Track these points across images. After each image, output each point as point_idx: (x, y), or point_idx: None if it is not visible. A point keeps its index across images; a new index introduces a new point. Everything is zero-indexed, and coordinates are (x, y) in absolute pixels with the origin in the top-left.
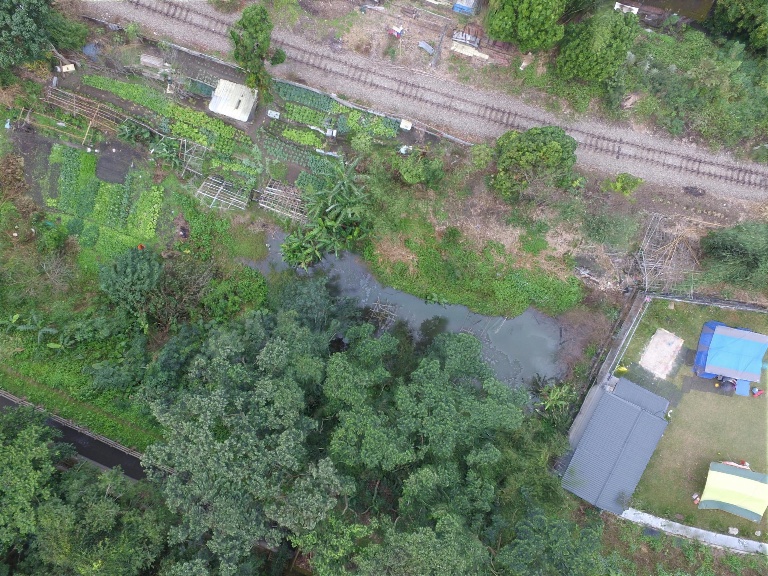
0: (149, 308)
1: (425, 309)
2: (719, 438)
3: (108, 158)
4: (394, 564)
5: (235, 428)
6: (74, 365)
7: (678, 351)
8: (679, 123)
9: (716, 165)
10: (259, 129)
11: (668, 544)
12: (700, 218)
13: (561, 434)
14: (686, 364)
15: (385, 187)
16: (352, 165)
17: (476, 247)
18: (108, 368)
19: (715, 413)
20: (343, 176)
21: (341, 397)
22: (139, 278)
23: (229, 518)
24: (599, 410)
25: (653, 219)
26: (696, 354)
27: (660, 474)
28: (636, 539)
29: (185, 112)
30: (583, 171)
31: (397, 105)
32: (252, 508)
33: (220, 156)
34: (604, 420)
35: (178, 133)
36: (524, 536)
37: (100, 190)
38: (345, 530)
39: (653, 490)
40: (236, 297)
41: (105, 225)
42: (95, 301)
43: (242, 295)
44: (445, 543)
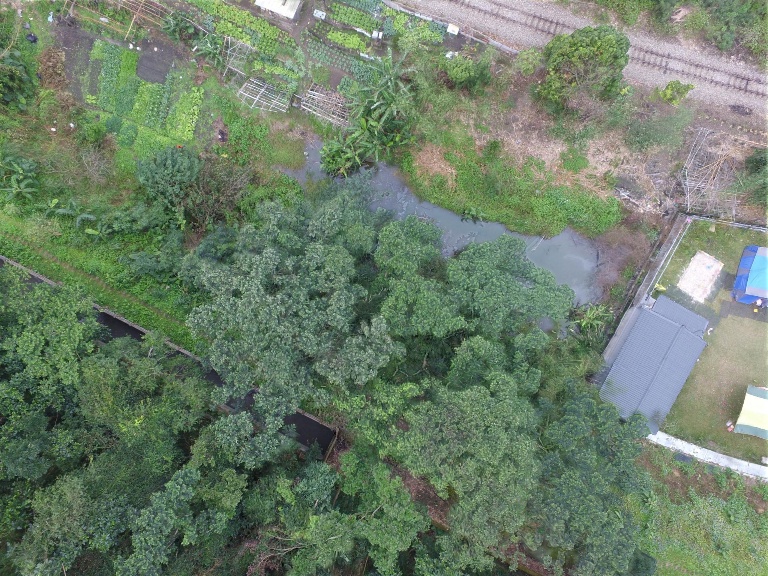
0: (188, 203)
1: (462, 225)
2: (756, 365)
3: (149, 57)
4: (447, 421)
5: (286, 288)
6: (111, 254)
7: (717, 275)
8: (730, 37)
9: (764, 84)
10: (303, 31)
11: (700, 470)
12: (746, 137)
13: (597, 352)
14: (725, 288)
15: (431, 88)
16: (400, 60)
17: (516, 163)
18: (145, 258)
19: (752, 340)
20: (390, 72)
21: (392, 266)
22: (179, 171)
23: (278, 374)
24: (637, 327)
25: (699, 134)
26: (735, 278)
27: (694, 400)
28: (668, 463)
29: (230, 10)
30: (629, 85)
31: (444, 11)
32: (301, 366)
33: (263, 57)
34: (642, 337)
35: (222, 32)
36: (573, 415)
37: (140, 89)
38: (396, 389)
39: (687, 416)
40: (273, 203)
41: (144, 125)
42: (132, 197)
43: (278, 202)
44: (500, 402)
